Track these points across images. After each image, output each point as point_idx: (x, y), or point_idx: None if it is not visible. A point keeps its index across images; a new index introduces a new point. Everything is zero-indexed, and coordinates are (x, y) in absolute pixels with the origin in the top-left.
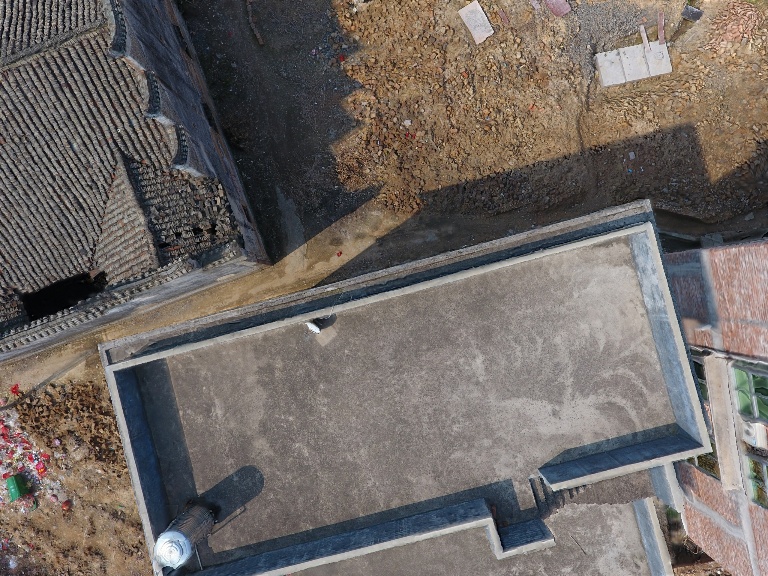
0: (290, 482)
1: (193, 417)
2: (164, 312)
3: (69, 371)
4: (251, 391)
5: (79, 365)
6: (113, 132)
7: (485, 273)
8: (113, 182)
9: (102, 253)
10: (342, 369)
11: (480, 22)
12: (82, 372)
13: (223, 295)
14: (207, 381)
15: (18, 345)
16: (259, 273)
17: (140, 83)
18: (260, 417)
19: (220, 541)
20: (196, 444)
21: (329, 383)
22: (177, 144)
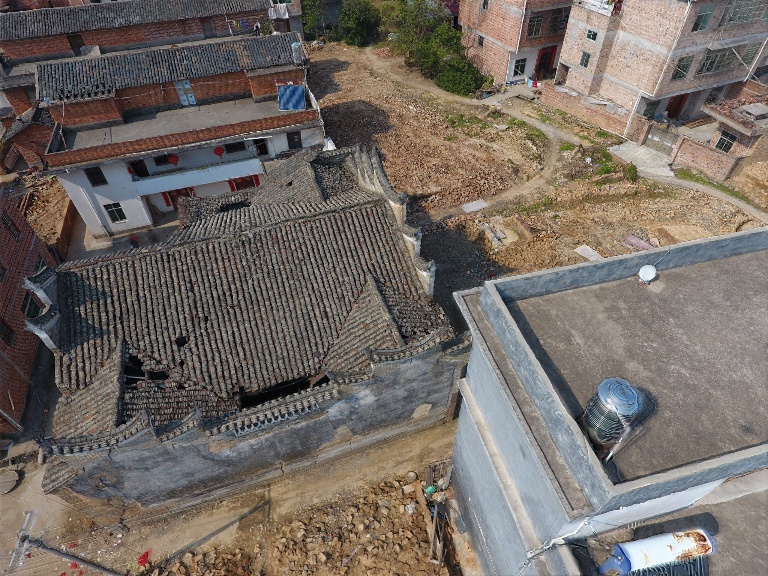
0: (683, 399)
1: (555, 345)
2: (338, 466)
3: (216, 535)
4: (605, 325)
5: (230, 527)
6: (368, 262)
7: (767, 250)
8: (360, 296)
9: (335, 354)
10: (685, 307)
11: (593, 254)
12: (231, 536)
13: (402, 449)
14: (560, 318)
15: (247, 423)
16: (439, 427)
17: (401, 228)
18: (622, 345)
19: (628, 464)
20: (565, 366)
21: (678, 318)
22: (425, 262)
